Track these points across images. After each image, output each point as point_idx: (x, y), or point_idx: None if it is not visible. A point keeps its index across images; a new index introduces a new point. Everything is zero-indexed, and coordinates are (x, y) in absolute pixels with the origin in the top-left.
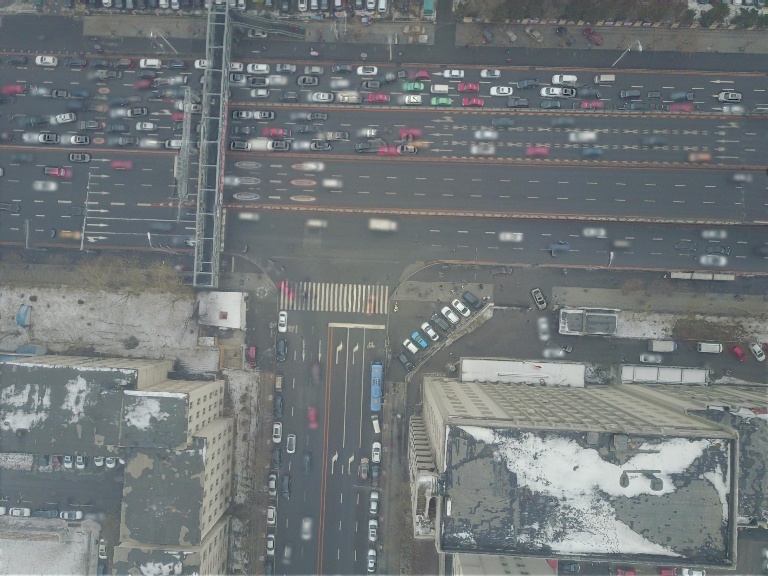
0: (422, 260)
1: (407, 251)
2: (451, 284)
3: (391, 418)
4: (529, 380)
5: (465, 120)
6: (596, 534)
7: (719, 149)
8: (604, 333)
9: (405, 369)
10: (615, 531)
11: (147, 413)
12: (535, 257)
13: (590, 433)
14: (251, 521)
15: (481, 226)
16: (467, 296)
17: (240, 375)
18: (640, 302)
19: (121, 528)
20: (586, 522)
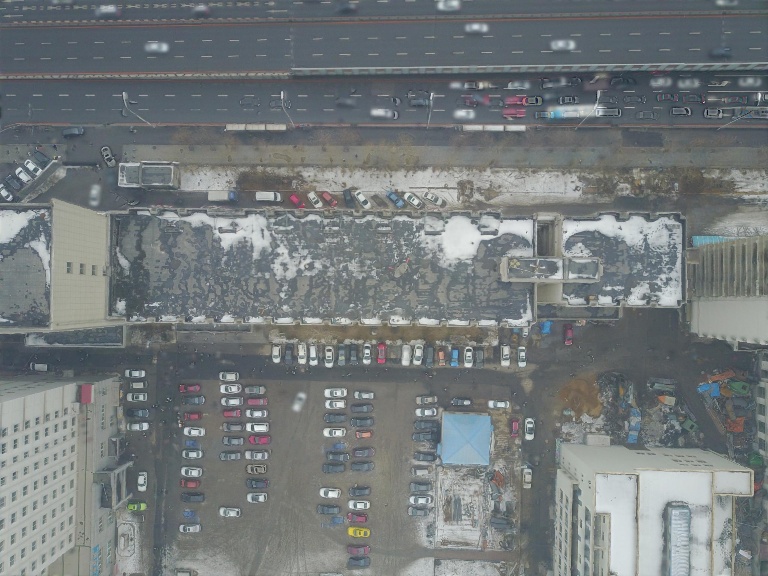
0: None
1: None
2: (26, 146)
3: None
4: None
5: None
6: None
7: (269, 3)
8: (159, 184)
9: None
10: None
11: None
12: (106, 117)
13: None
14: None
15: (55, 89)
16: (36, 155)
17: None
18: (206, 156)
19: None
20: None
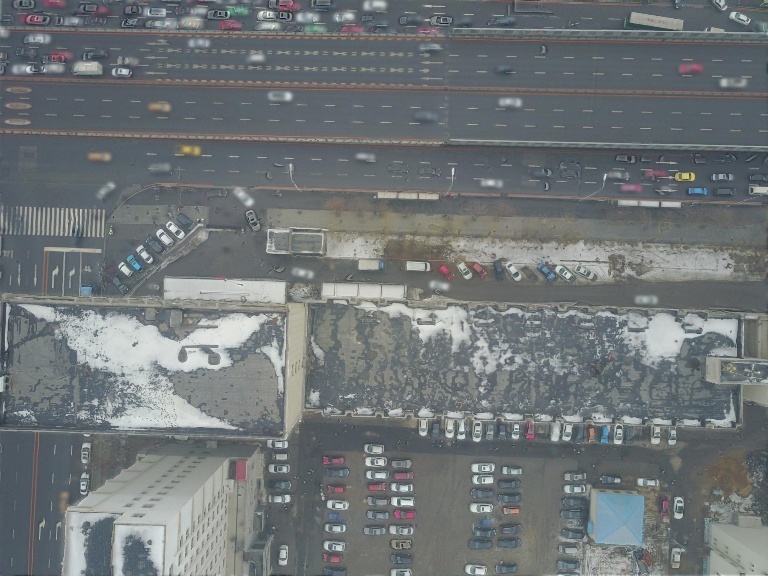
0: (139, 183)
1: (124, 175)
2: (167, 207)
3: None
4: (231, 298)
5: (180, 43)
6: (154, 409)
7: (424, 70)
8: (310, 252)
9: (120, 292)
10: (173, 406)
11: None
12: (251, 180)
13: (148, 309)
14: None
15: (197, 149)
16: (179, 218)
17: None
18: (353, 223)
19: None
20: (144, 397)
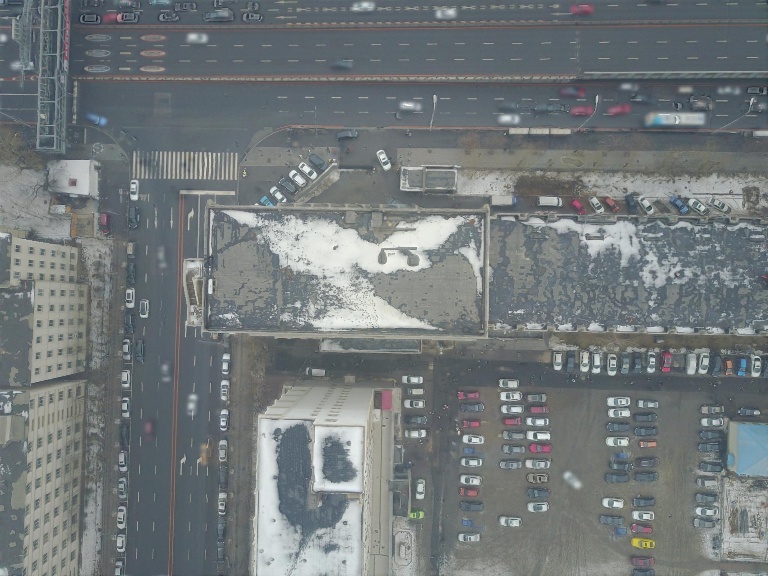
0: (270, 126)
1: (256, 118)
2: (298, 149)
3: None
4: None
5: None
6: (356, 310)
7: (554, 6)
8: (443, 188)
9: None
10: (374, 307)
11: None
12: (380, 120)
13: (348, 212)
14: (106, 385)
15: (327, 91)
16: (312, 158)
17: (93, 243)
18: (483, 161)
19: None
20: (346, 299)
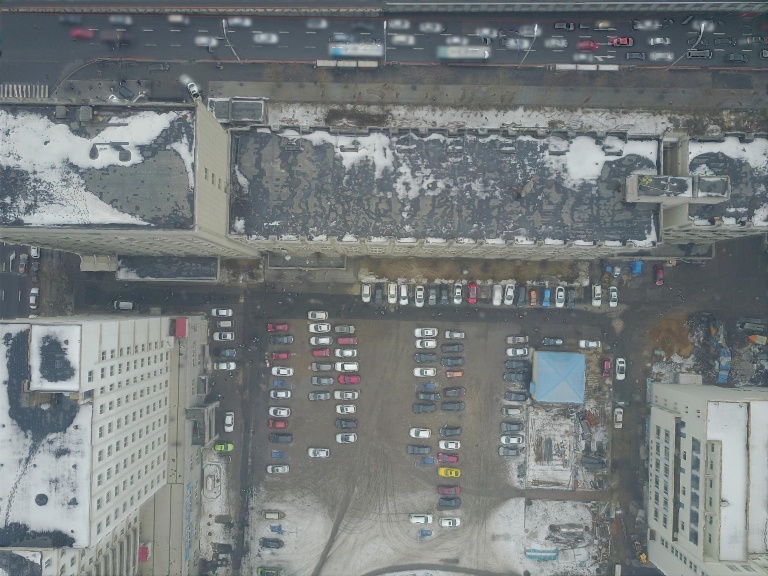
0: (81, 59)
1: (67, 51)
2: (109, 81)
3: None
4: None
5: None
6: (66, 206)
7: None
8: (250, 119)
9: None
10: (85, 202)
11: None
12: (192, 53)
13: (58, 107)
14: None
15: (139, 24)
16: (121, 90)
17: None
18: (294, 94)
19: None
20: (57, 194)
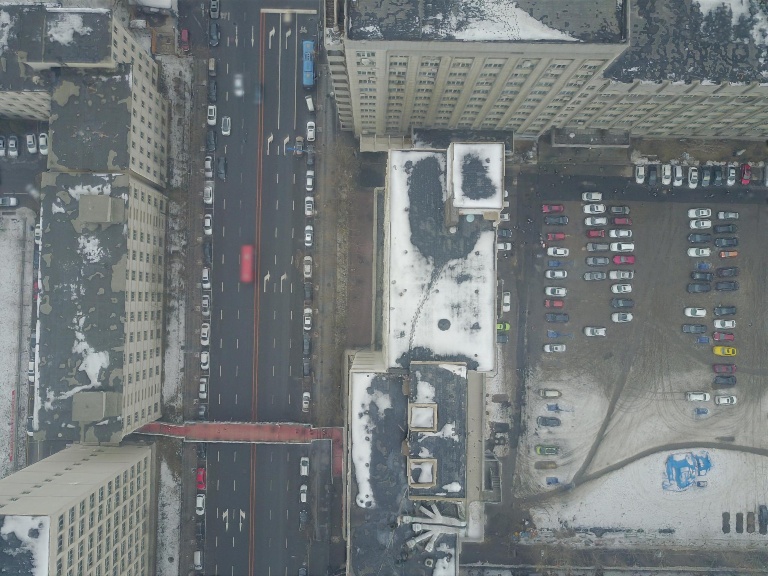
0: None
1: None
2: None
3: (325, 99)
4: None
5: None
6: (498, 22)
7: None
8: None
9: None
10: (516, 18)
11: (70, 28)
12: None
13: None
14: (188, 203)
15: None
16: None
17: (173, 61)
18: None
19: (48, 155)
20: (488, 11)
